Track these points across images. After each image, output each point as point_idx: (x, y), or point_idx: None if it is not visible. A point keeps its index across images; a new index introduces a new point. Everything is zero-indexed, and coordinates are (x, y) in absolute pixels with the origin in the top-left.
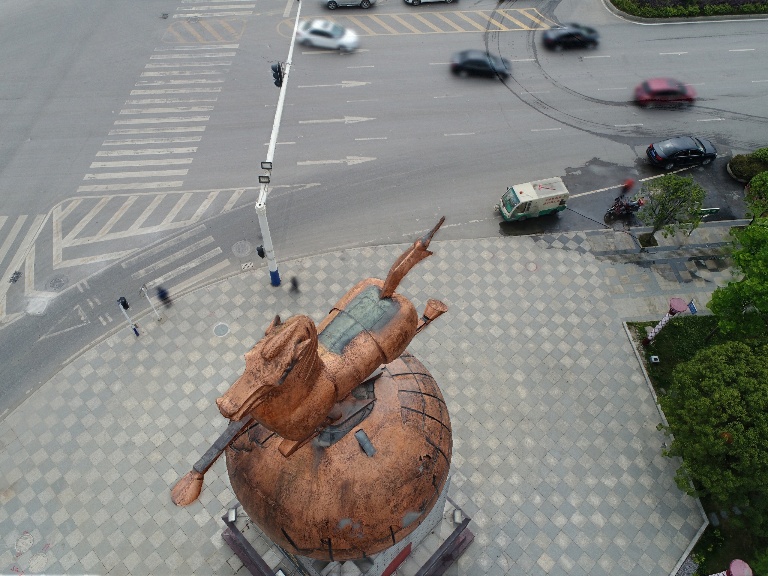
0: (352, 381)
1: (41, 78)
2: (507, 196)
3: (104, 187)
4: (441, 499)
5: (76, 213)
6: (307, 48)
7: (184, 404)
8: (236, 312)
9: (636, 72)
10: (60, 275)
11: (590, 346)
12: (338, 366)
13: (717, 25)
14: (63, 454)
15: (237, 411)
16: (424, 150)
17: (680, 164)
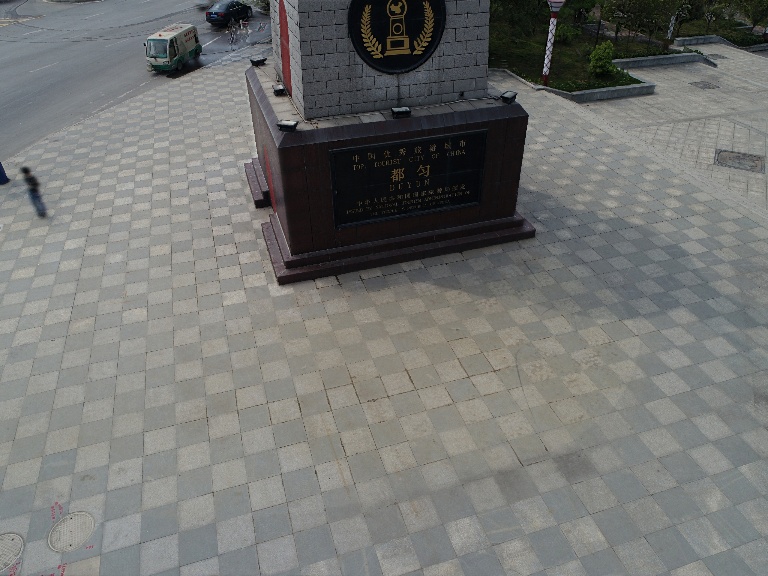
0: None
1: None
2: None
3: None
4: None
5: None
6: None
7: (42, 281)
8: None
9: (137, 11)
10: None
11: None
12: None
13: None
14: None
15: None
16: (24, 82)
17: (237, 17)
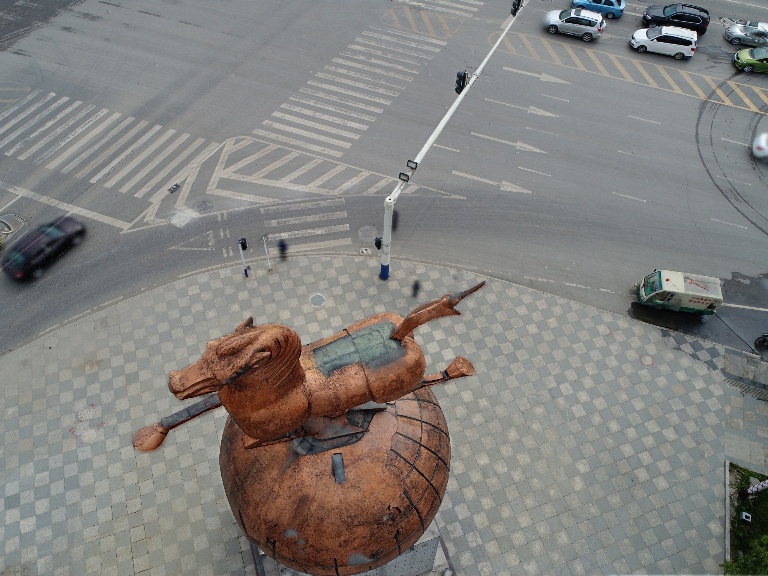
0: (329, 406)
1: (266, 24)
2: (652, 278)
3: (275, 136)
4: (428, 552)
5: (244, 151)
6: (510, 64)
7: None
8: (337, 289)
9: None
10: (209, 200)
11: (676, 470)
12: (319, 386)
13: None
14: (146, 353)
15: (182, 390)
16: (584, 200)
17: None
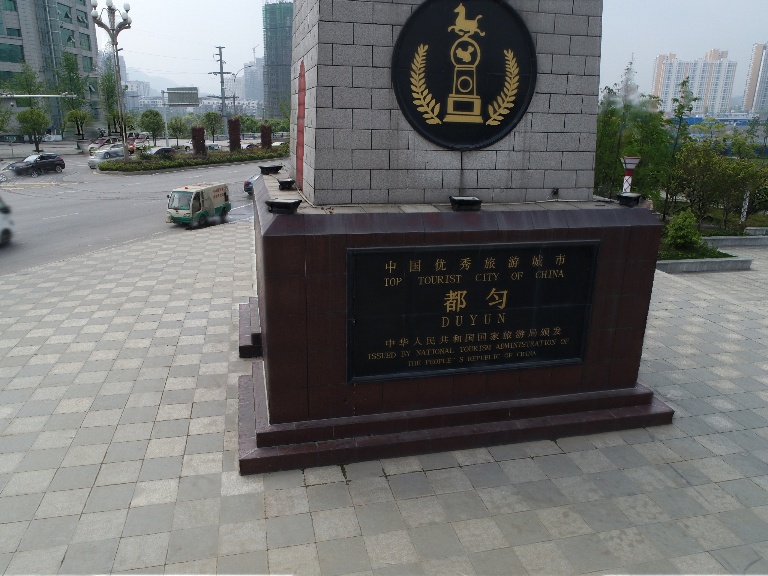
0: None
1: None
2: None
3: None
4: None
5: None
6: None
7: None
8: None
9: None
10: None
11: None
12: None
13: (204, 169)
14: None
15: None
16: (30, 226)
17: None
